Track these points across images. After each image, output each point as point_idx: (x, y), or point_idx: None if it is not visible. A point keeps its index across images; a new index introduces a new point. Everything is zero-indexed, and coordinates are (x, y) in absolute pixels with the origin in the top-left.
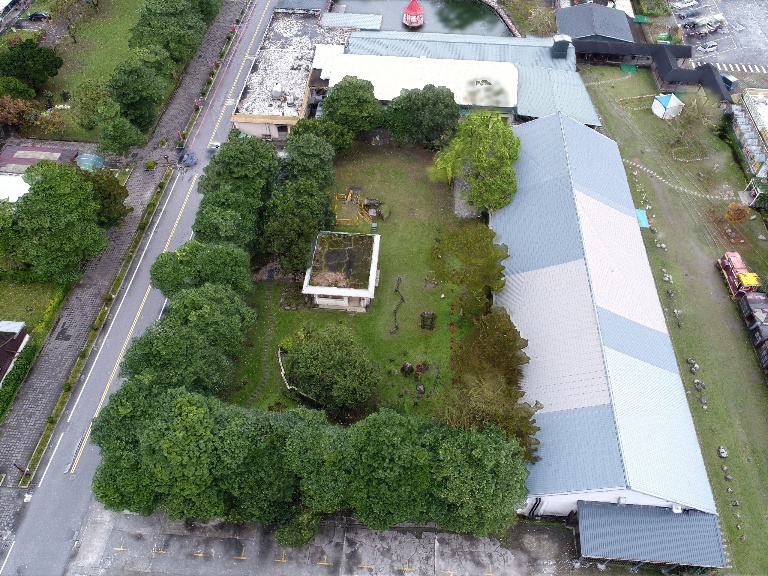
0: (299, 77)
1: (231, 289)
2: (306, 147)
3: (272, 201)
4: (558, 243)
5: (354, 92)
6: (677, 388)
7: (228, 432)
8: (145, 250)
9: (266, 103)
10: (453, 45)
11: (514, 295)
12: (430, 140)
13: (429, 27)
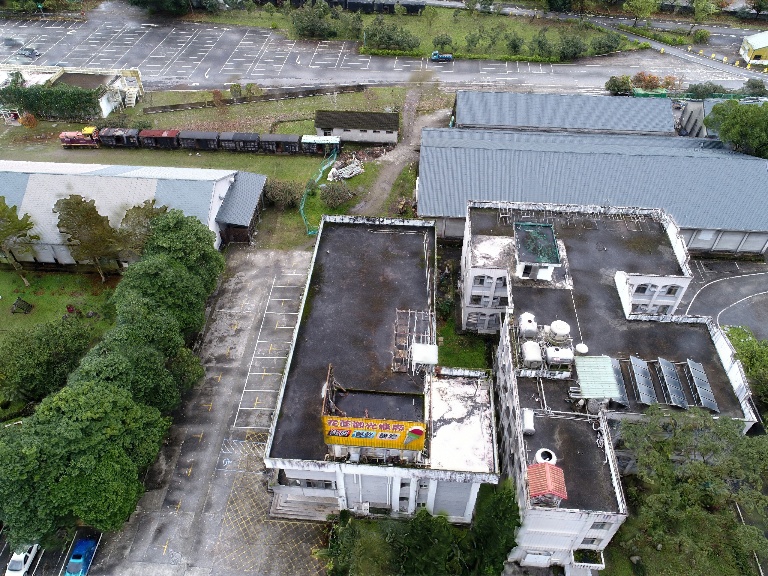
0: None
1: None
2: None
3: None
4: (3, 189)
5: None
6: (156, 168)
7: (94, 368)
8: None
9: None
10: None
11: (36, 229)
12: None
13: None
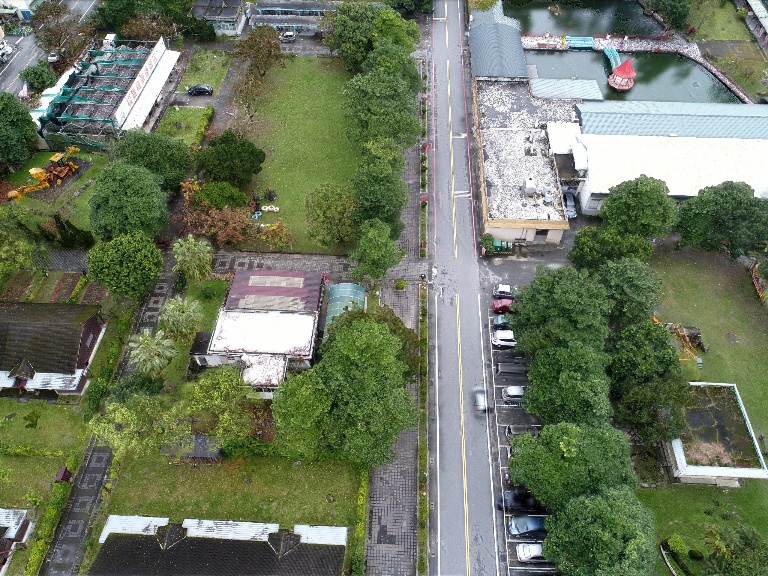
0: (540, 165)
1: (629, 490)
2: (635, 277)
3: (626, 356)
4: None
5: (657, 198)
6: None
7: None
8: (437, 405)
9: (517, 201)
10: (702, 119)
11: None
12: (735, 248)
13: (637, 89)
